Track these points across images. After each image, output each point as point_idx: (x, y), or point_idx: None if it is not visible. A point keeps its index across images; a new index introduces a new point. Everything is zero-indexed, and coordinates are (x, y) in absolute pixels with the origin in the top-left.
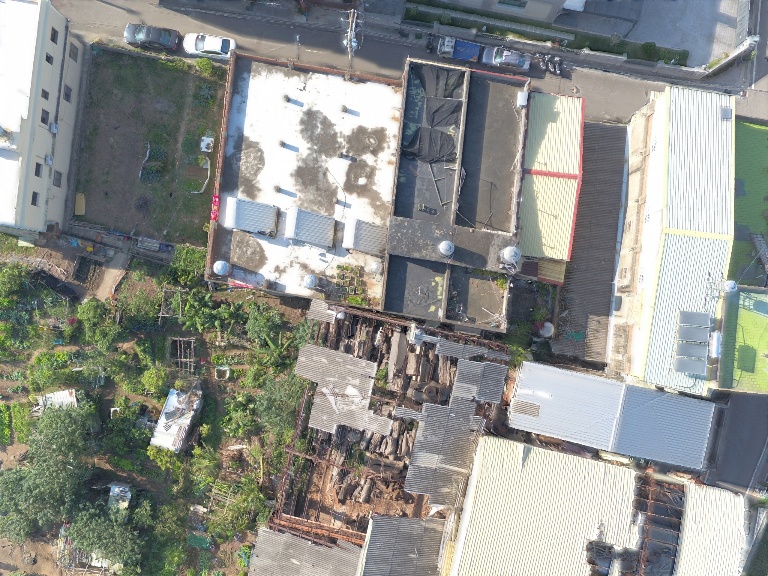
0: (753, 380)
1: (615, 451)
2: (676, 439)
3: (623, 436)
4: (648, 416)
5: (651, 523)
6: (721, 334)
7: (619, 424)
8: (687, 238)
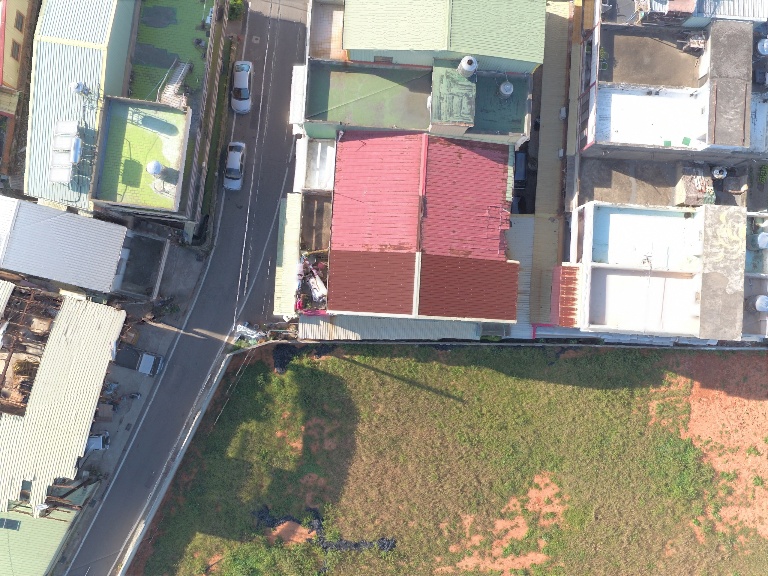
0: (138, 195)
1: (4, 267)
2: (79, 260)
3: (13, 252)
4: (44, 234)
5: (122, 368)
6: (97, 145)
7: (9, 240)
8: (60, 46)
